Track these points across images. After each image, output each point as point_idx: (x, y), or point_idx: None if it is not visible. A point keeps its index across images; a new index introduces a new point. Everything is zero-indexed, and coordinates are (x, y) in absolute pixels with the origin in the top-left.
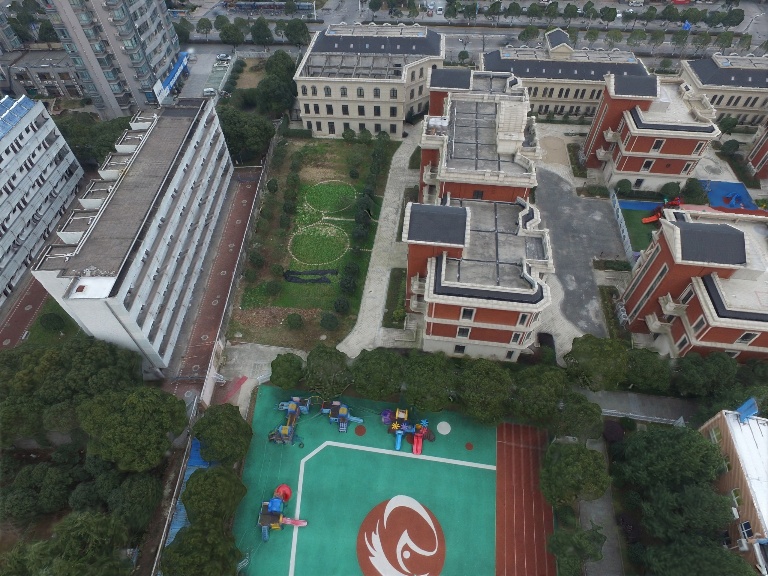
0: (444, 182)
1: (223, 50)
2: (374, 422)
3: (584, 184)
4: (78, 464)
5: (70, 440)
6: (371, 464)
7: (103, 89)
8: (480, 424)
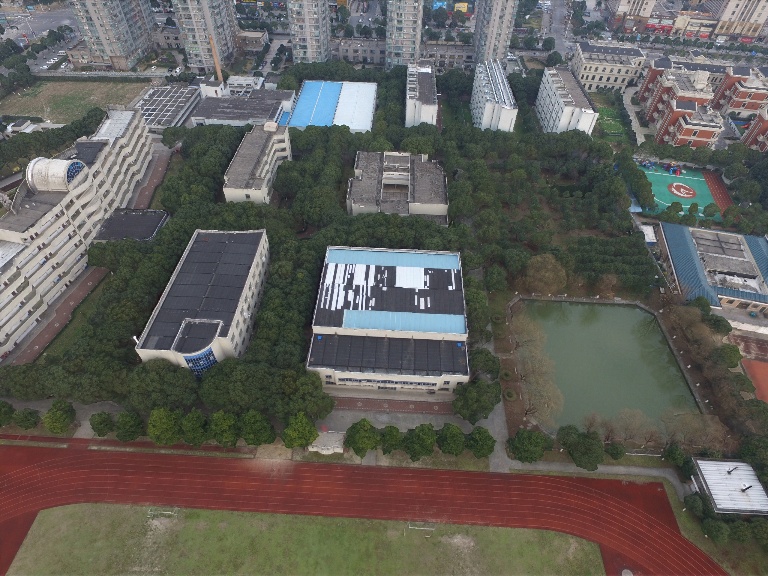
0: (678, 96)
1: None
2: (660, 169)
3: None
4: None
5: None
6: None
7: None
8: (696, 171)
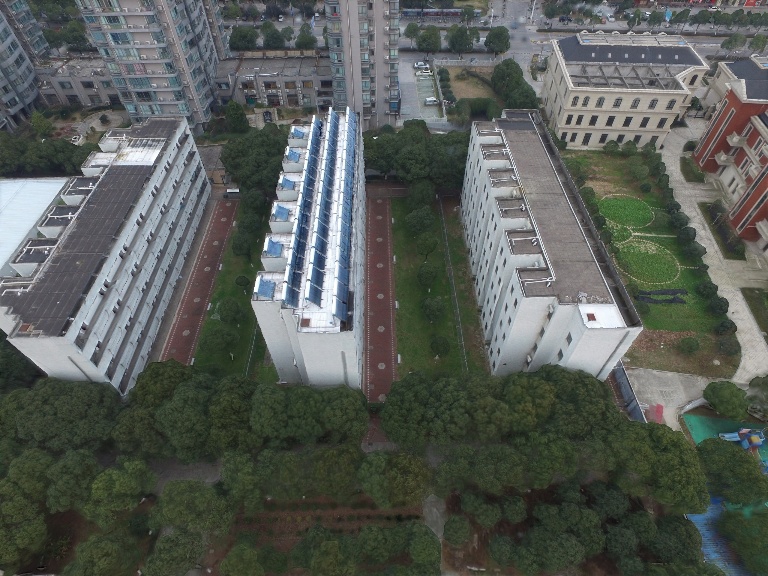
0: None
1: (413, 58)
2: None
3: None
4: (593, 504)
5: (564, 477)
6: None
7: (353, 99)
8: None
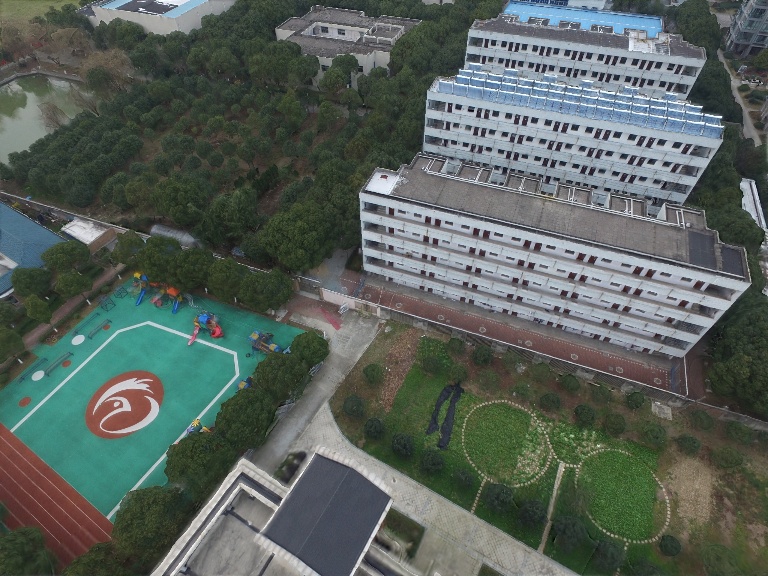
0: None
1: None
2: None
3: None
4: None
5: None
6: (196, 403)
7: None
8: None
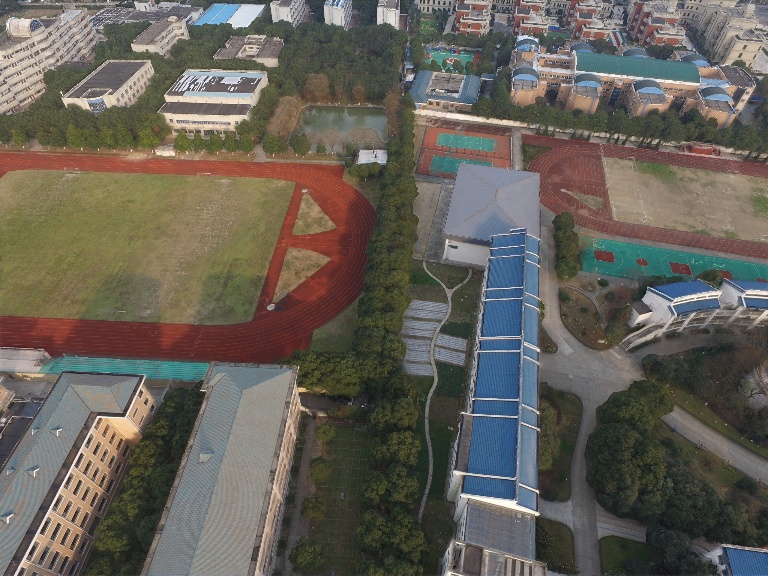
0: None
1: None
2: (446, 51)
3: (509, 23)
4: None
5: None
6: None
7: None
8: (471, 52)
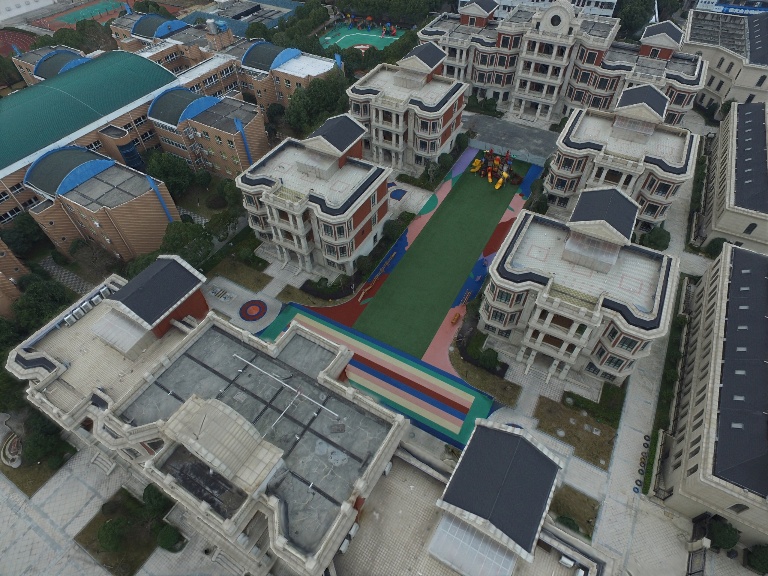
0: None
1: None
2: None
3: None
4: None
5: None
6: None
7: None
8: None
